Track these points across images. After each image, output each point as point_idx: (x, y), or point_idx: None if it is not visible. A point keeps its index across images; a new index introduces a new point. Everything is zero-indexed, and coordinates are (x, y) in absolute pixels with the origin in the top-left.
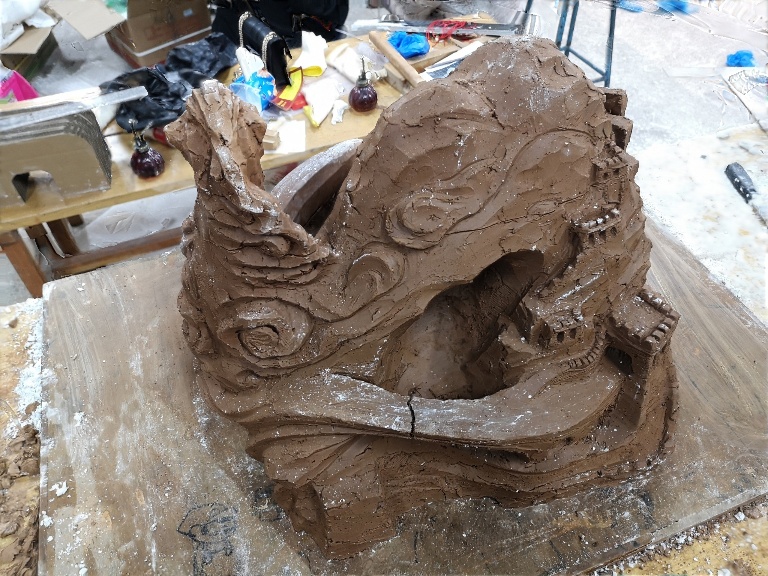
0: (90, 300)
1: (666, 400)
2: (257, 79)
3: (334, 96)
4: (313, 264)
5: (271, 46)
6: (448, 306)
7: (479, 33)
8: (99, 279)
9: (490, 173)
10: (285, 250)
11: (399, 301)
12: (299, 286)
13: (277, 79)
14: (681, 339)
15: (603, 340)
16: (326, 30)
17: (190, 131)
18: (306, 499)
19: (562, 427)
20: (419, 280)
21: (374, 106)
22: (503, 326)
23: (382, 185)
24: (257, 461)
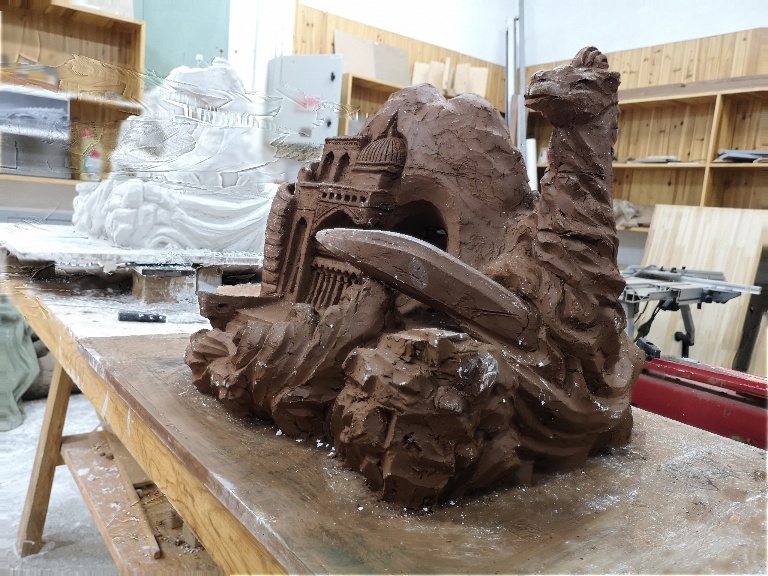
0: None
1: None
2: None
3: None
4: None
5: None
6: None
7: None
8: None
9: None
10: None
11: None
12: None
13: None
14: None
15: None
16: None
17: None
18: None
19: None
20: None
21: None
22: None
23: None
24: (608, 462)
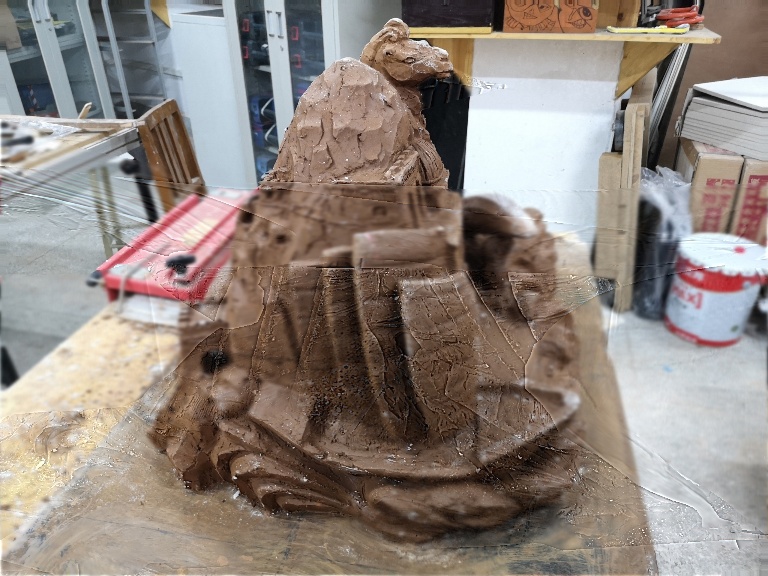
0: None
1: None
2: None
3: None
4: None
5: None
6: None
7: None
8: None
9: None
10: None
11: None
12: None
13: None
14: (208, 570)
15: None
16: None
17: None
18: None
19: None
20: None
21: None
22: None
23: None
24: None
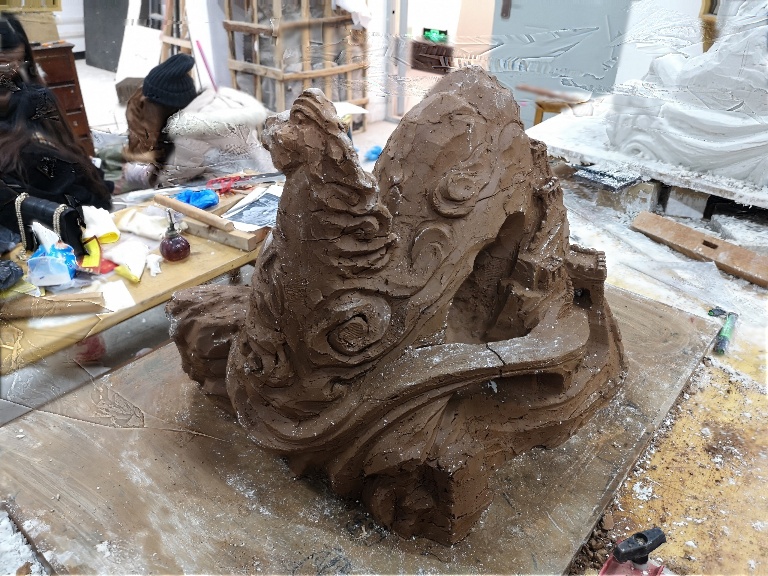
0: (40, 442)
1: (611, 327)
2: (57, 251)
3: (144, 253)
4: (385, 248)
5: (64, 218)
6: None
7: (255, 182)
8: (38, 421)
9: (488, 153)
10: (378, 229)
11: (457, 263)
12: (374, 274)
13: (74, 250)
14: None
15: (570, 280)
16: (104, 204)
17: (305, 129)
18: (415, 491)
19: (582, 342)
20: (466, 243)
21: (188, 253)
22: (508, 286)
23: (423, 172)
24: (329, 503)
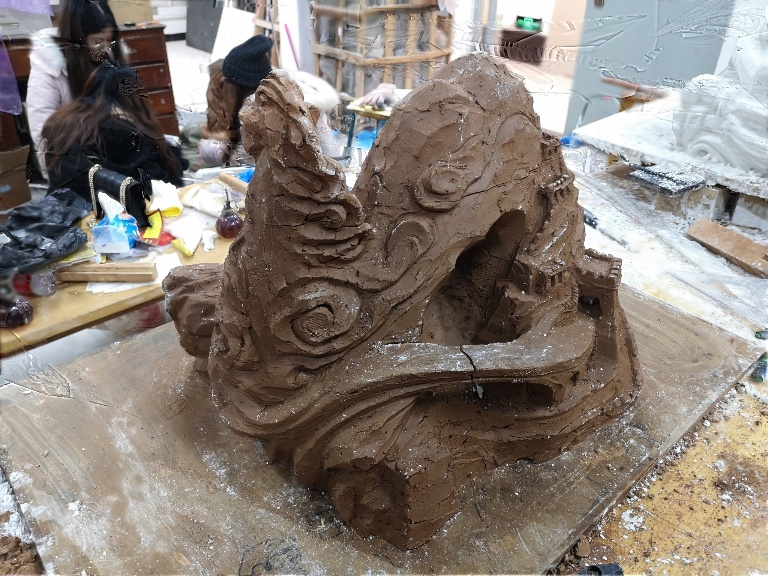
0: (43, 399)
1: (626, 340)
2: (120, 221)
3: (200, 228)
4: (358, 239)
5: (130, 190)
6: (442, 296)
7: None
8: None
9: (483, 145)
10: (345, 218)
11: (436, 259)
12: (346, 264)
13: (137, 221)
14: None
15: (577, 287)
16: None
17: (267, 111)
18: (374, 490)
19: (577, 354)
20: (448, 239)
21: None
22: (503, 288)
23: (406, 162)
24: (295, 491)
